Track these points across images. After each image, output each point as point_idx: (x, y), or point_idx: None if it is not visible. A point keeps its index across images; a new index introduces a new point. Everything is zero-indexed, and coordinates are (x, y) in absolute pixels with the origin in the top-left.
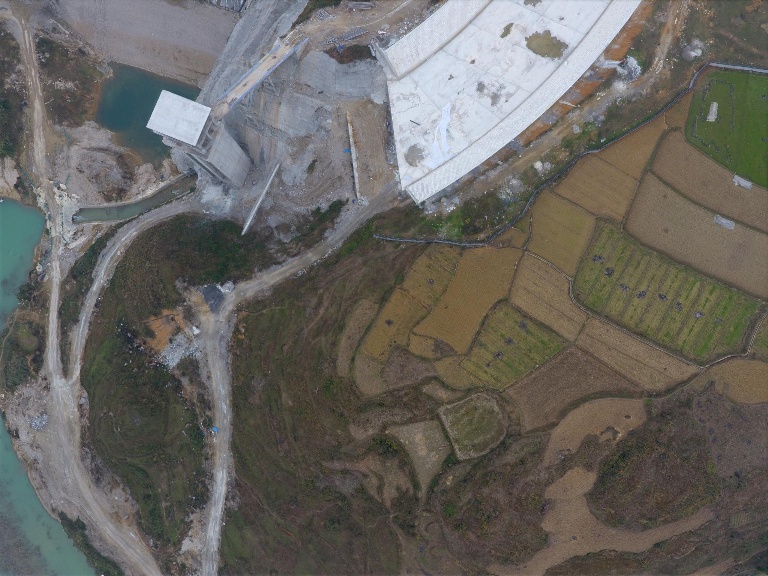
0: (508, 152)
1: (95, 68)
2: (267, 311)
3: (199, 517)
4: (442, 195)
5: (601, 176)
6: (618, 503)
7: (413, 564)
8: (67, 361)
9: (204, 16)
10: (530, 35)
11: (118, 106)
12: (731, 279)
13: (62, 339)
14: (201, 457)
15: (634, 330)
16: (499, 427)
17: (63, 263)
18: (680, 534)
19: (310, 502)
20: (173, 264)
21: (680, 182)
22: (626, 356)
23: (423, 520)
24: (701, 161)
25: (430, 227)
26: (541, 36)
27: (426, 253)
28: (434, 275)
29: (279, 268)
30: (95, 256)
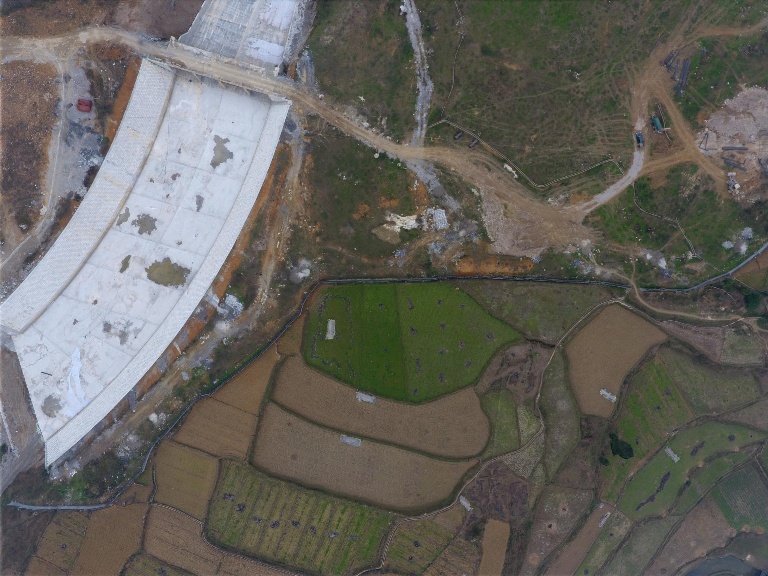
0: (125, 406)
1: None
2: None
3: None
4: (67, 457)
5: (219, 417)
6: None
7: None
8: None
9: None
10: (150, 265)
11: None
12: (363, 494)
13: None
14: None
15: (272, 559)
16: None
17: None
18: None
19: None
20: None
21: (304, 407)
22: None
23: None
24: (322, 382)
25: (57, 493)
26: (161, 265)
27: (55, 521)
28: (66, 540)
29: None
30: None
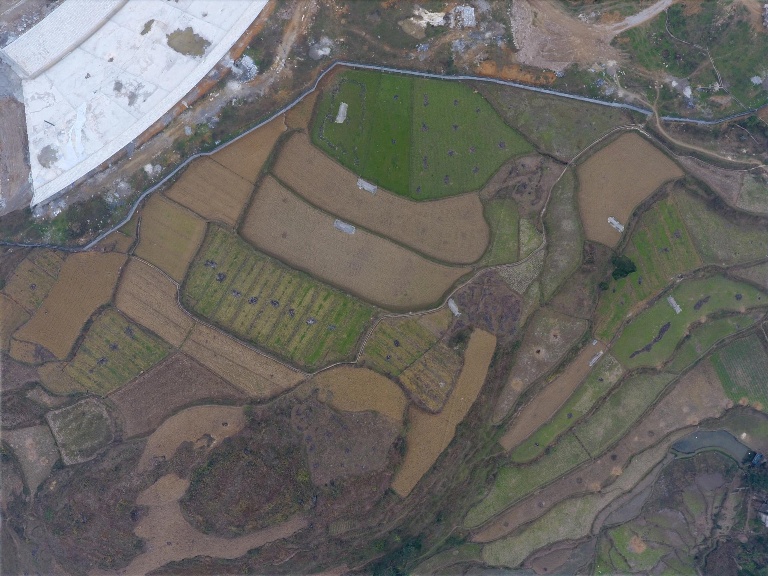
0: (122, 154)
1: None
2: None
3: None
4: (55, 198)
5: (215, 179)
6: (205, 510)
7: (29, 567)
8: None
9: None
10: (171, 32)
11: None
12: (349, 285)
13: None
14: None
15: (244, 336)
16: (107, 433)
17: None
18: (273, 541)
19: None
20: None
21: (302, 185)
22: (232, 363)
23: (30, 524)
24: (325, 164)
25: (37, 231)
26: (183, 33)
27: (29, 257)
28: (37, 280)
29: None
30: None
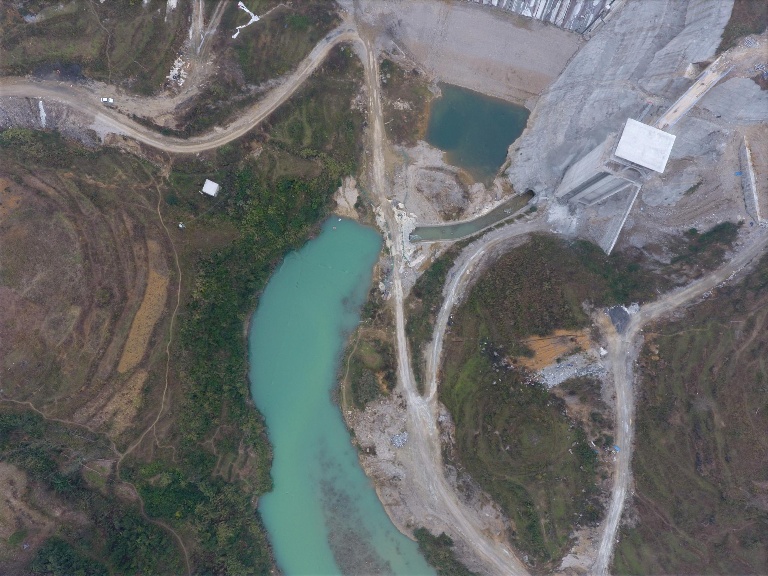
0: None
1: (426, 88)
2: (684, 333)
3: (588, 534)
4: None
5: None
6: None
7: None
8: (423, 379)
9: (549, 38)
10: None
11: (445, 126)
12: None
13: (416, 357)
14: (595, 475)
15: None
16: None
17: (404, 281)
18: None
19: (727, 521)
20: (578, 286)
21: None
22: None
23: None
24: None
25: None
26: None
27: None
28: None
29: (684, 290)
30: (442, 275)
